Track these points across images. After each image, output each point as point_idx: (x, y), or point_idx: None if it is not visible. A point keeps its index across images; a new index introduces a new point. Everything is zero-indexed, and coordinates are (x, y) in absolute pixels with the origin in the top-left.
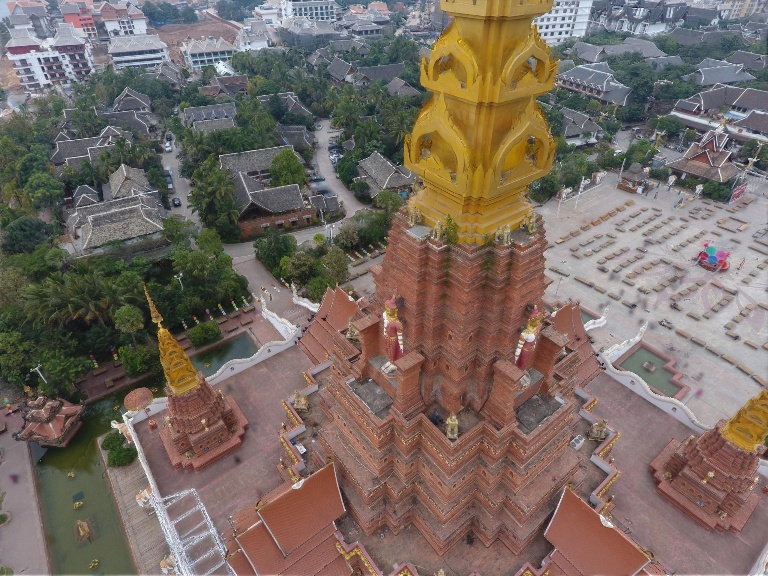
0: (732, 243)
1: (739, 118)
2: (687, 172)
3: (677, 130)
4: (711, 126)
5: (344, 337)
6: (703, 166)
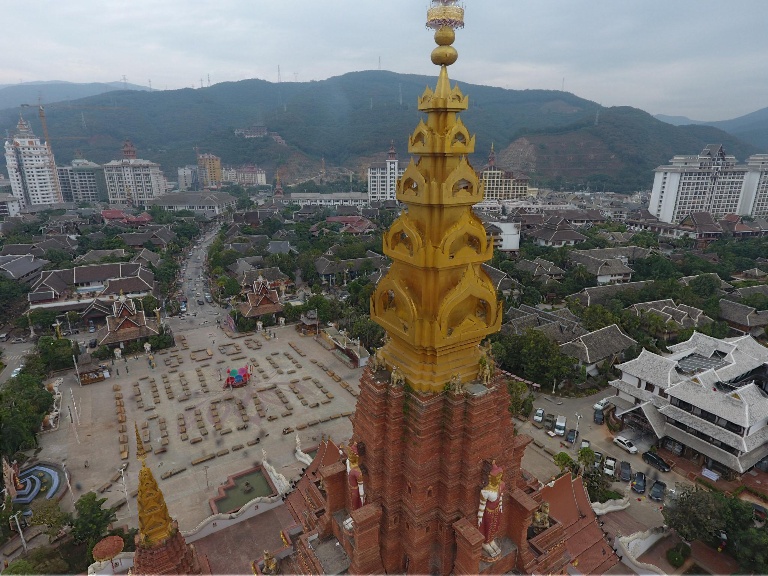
0: (221, 364)
1: (94, 290)
2: (124, 340)
3: (54, 318)
4: (82, 303)
5: None
6: (132, 330)
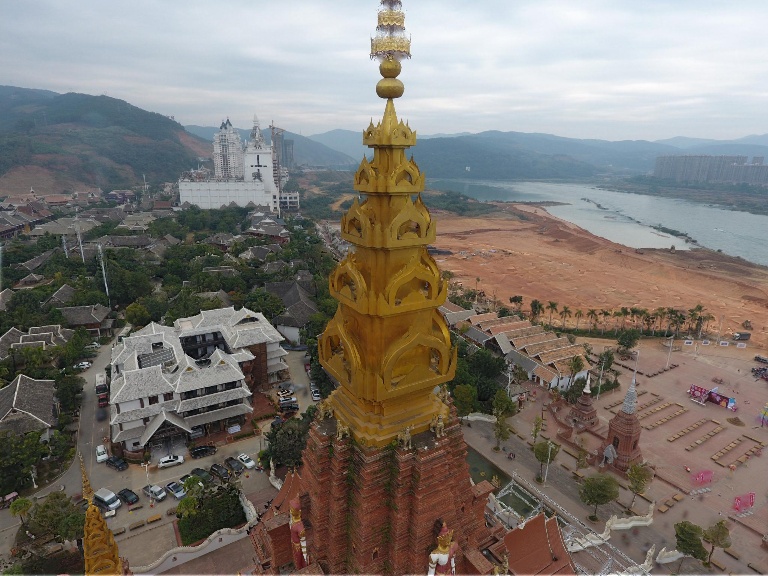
0: None
1: None
2: None
3: None
4: None
5: (511, 570)
6: None
